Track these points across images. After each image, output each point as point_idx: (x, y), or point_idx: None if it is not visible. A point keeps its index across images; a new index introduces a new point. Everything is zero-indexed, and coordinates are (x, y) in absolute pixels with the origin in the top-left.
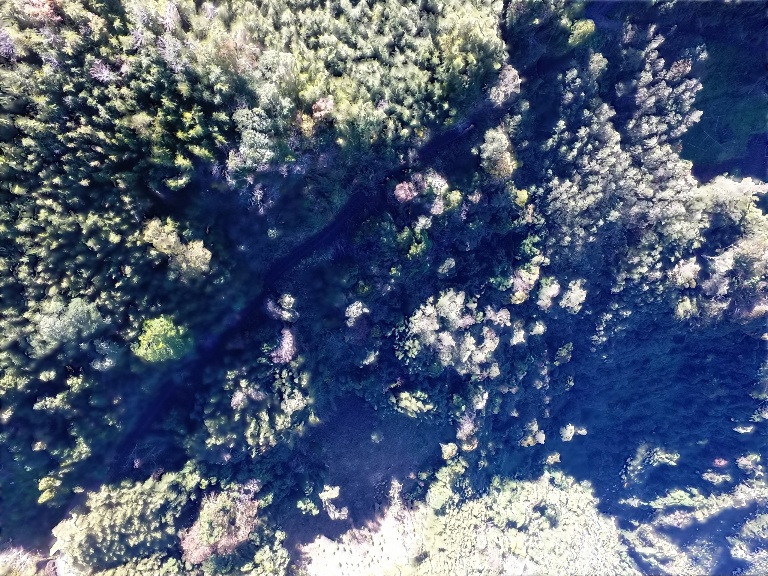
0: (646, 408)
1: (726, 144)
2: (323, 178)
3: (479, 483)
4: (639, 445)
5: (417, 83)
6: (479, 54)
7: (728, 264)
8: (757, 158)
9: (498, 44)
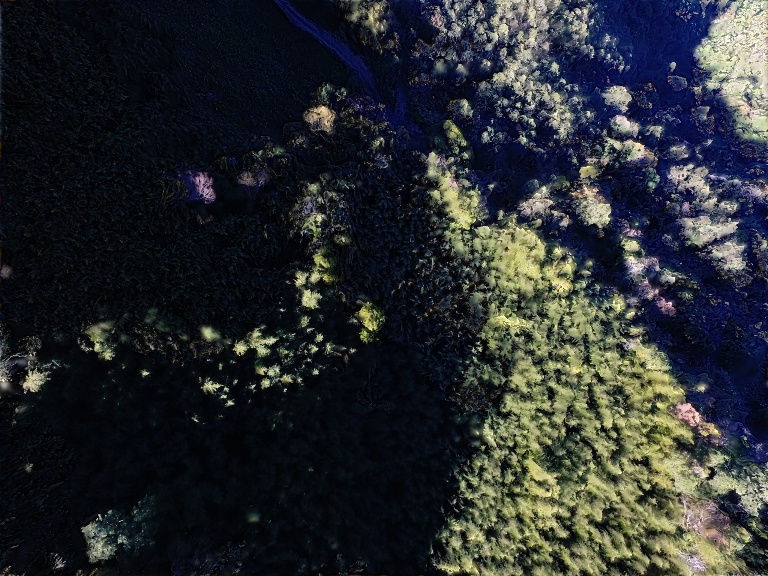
0: (634, 2)
1: None
2: (699, 397)
3: (763, 170)
4: (667, 5)
5: None
6: (548, 246)
7: None
8: None
9: None
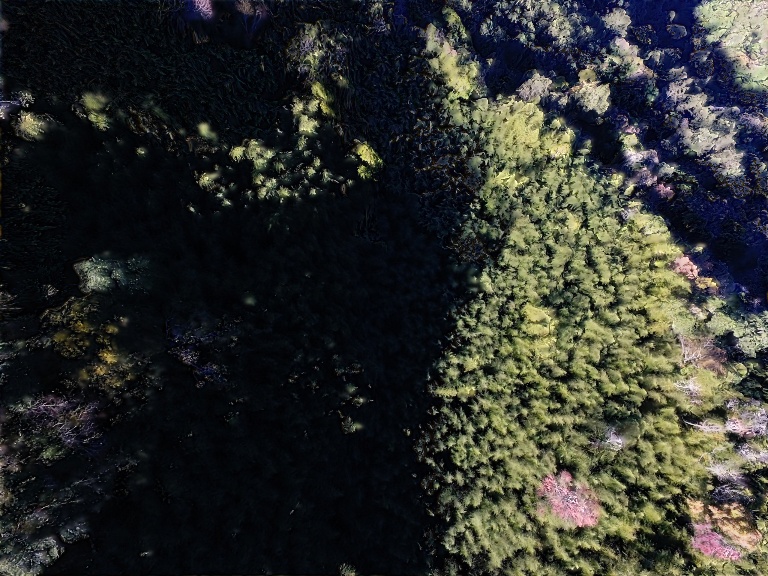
0: None
1: None
2: None
3: None
4: None
5: None
6: (547, 117)
7: None
8: None
9: None
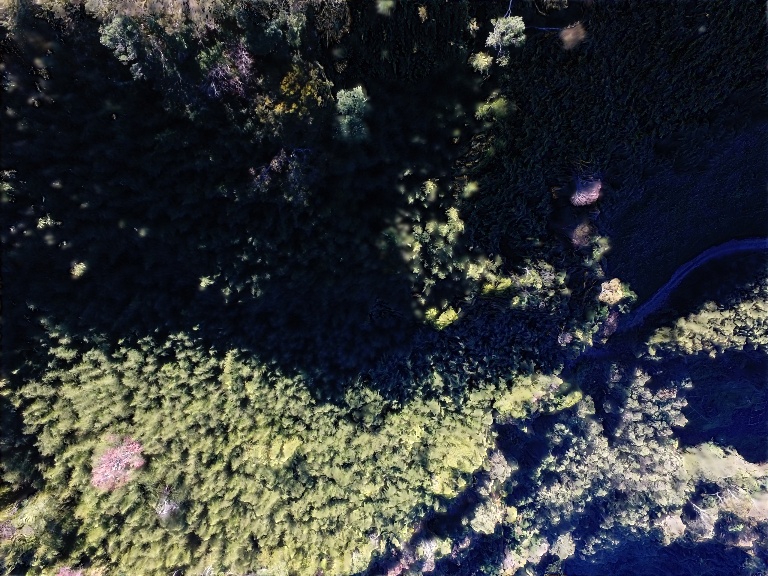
0: (635, 569)
1: (711, 418)
2: None
3: None
4: None
5: (408, 506)
6: (469, 475)
7: (713, 522)
8: (741, 425)
9: (488, 446)
